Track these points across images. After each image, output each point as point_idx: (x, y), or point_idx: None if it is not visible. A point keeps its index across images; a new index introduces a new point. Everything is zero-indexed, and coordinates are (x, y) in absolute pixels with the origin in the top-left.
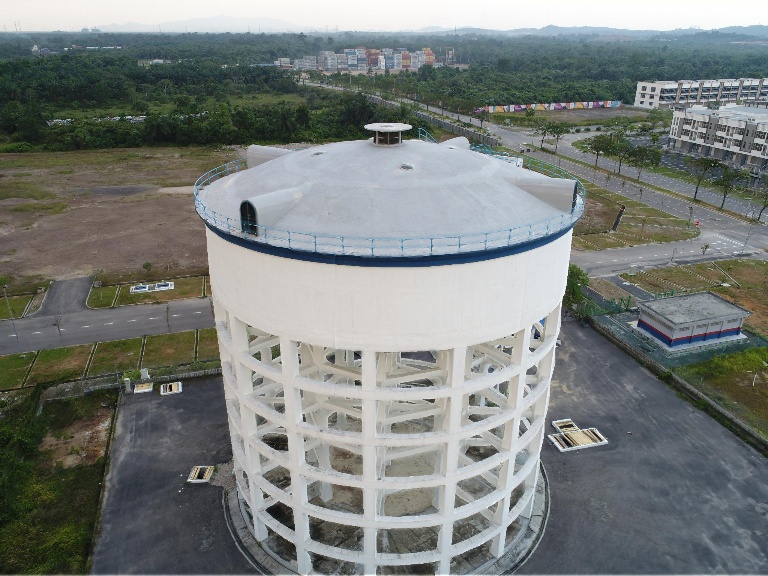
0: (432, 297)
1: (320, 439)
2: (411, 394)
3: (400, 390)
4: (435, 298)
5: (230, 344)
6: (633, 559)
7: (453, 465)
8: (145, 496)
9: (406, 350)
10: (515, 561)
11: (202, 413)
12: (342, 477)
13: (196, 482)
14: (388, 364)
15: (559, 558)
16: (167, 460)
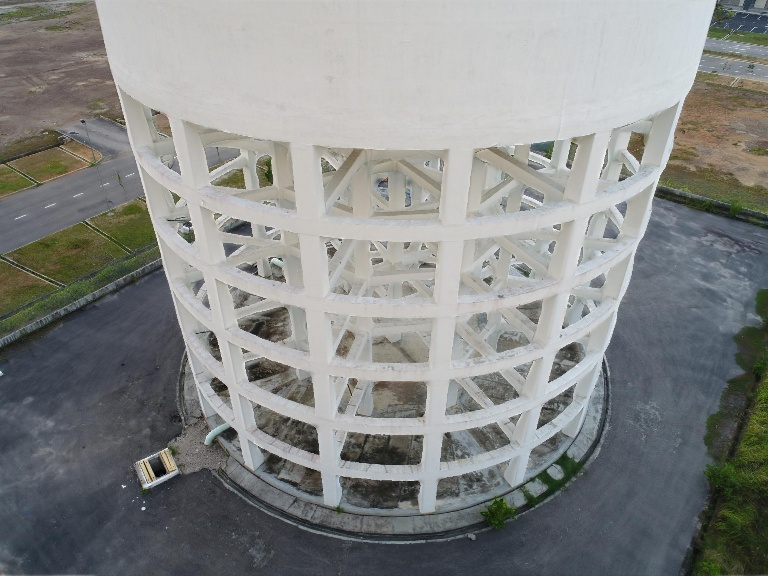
0: (691, 9)
1: (366, 333)
2: (630, 190)
3: (617, 188)
4: (692, 11)
5: (281, 213)
6: (675, 324)
7: (625, 281)
8: (89, 546)
9: (645, 115)
10: (602, 374)
11: (71, 388)
12: (518, 354)
13: (159, 483)
14: (401, 202)
15: (629, 352)
16: (76, 477)
